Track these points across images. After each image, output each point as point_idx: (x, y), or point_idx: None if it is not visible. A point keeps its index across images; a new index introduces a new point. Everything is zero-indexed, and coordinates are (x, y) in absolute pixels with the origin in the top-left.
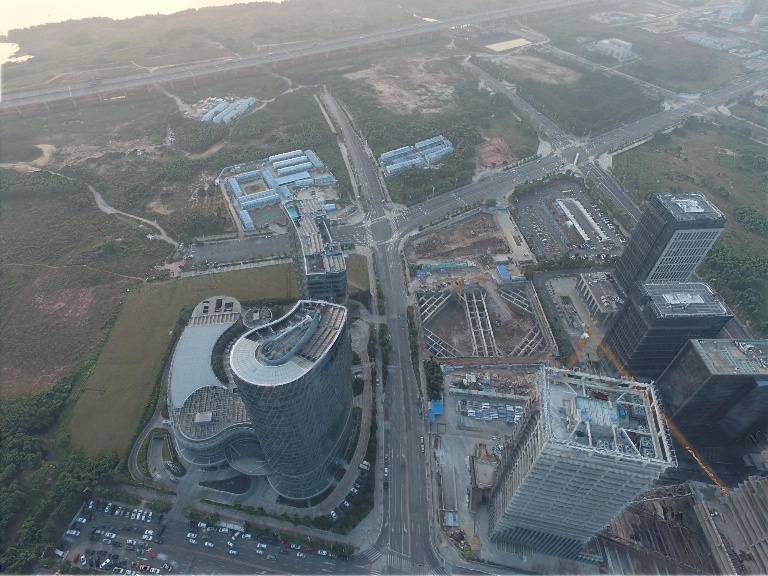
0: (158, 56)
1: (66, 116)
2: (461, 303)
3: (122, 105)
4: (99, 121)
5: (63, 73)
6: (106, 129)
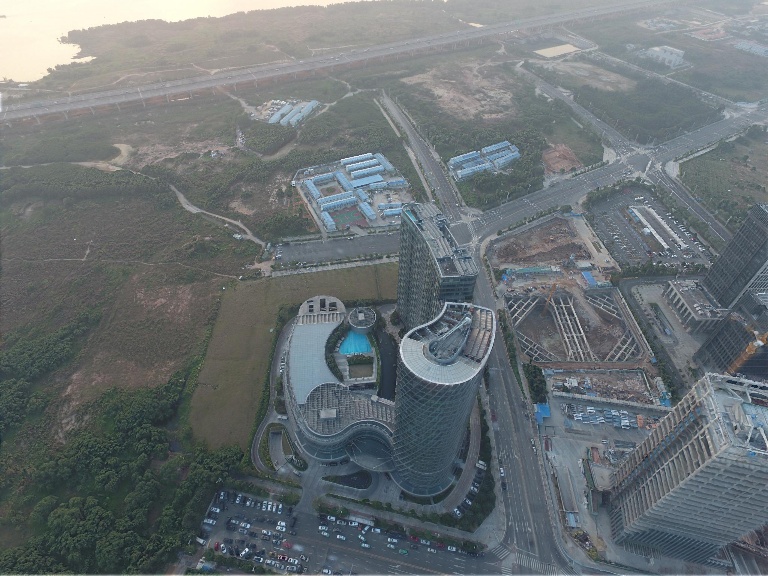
0: (216, 59)
1: (137, 117)
2: (548, 308)
3: (190, 106)
4: (170, 122)
5: (128, 74)
6: (178, 130)
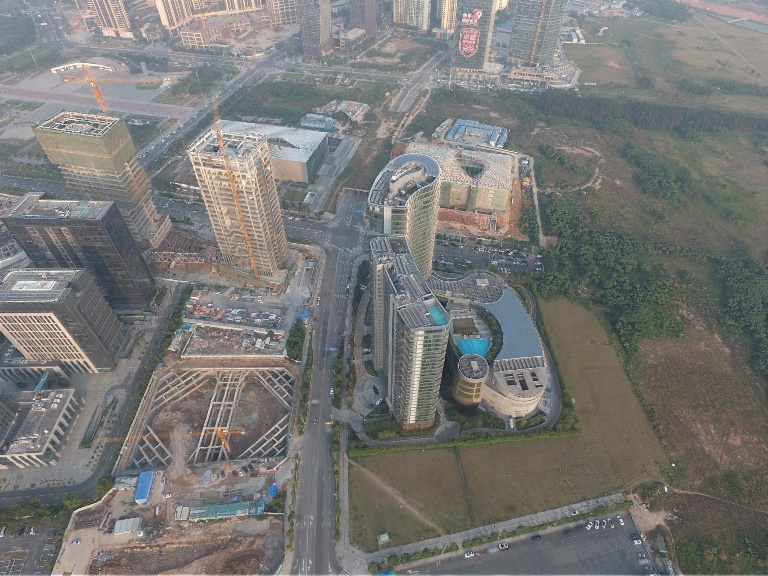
0: None
1: None
2: None
3: None
4: None
5: None
6: None
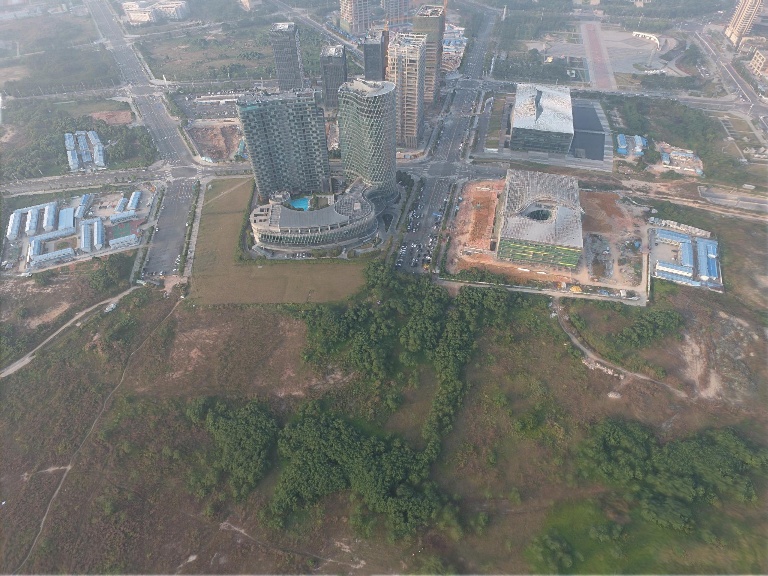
0: None
1: None
2: None
3: None
4: None
5: None
6: None
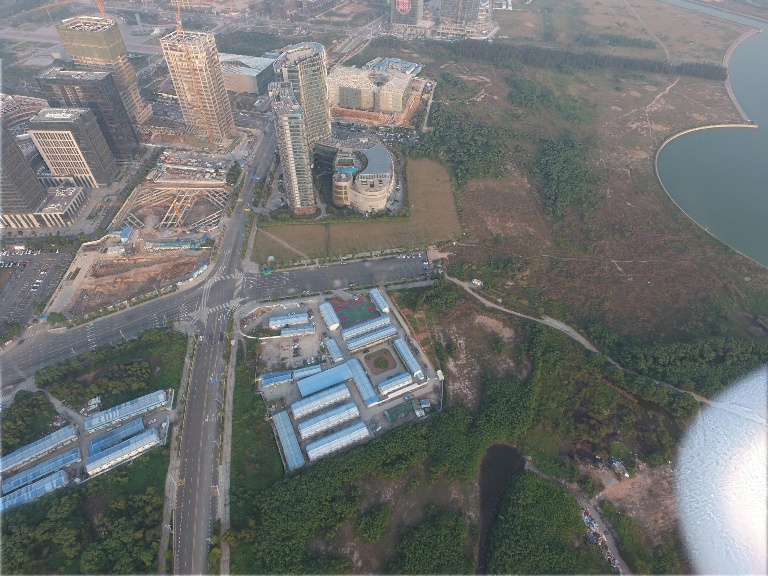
0: None
1: None
2: None
3: None
4: None
5: None
6: None
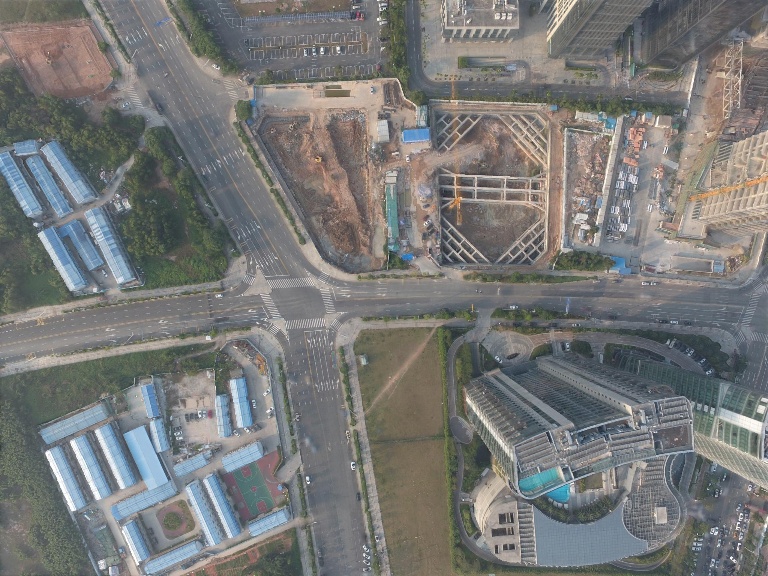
0: None
1: None
2: None
3: None
4: None
5: None
6: None
